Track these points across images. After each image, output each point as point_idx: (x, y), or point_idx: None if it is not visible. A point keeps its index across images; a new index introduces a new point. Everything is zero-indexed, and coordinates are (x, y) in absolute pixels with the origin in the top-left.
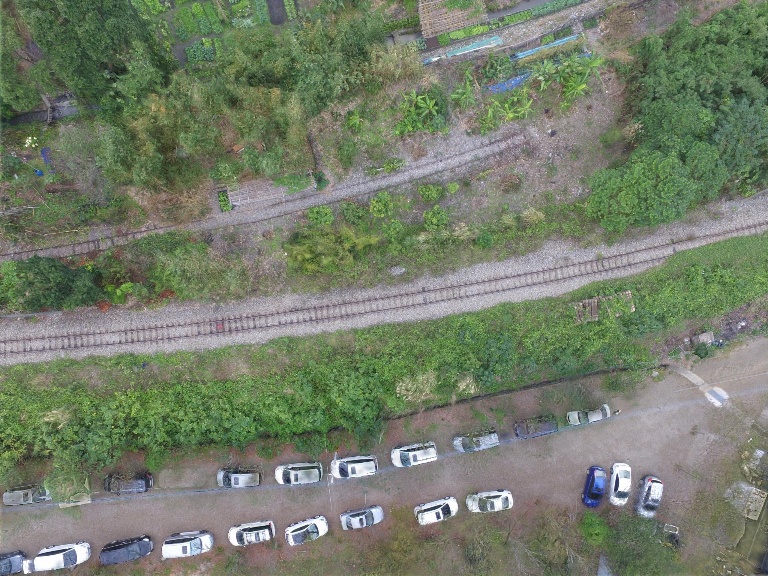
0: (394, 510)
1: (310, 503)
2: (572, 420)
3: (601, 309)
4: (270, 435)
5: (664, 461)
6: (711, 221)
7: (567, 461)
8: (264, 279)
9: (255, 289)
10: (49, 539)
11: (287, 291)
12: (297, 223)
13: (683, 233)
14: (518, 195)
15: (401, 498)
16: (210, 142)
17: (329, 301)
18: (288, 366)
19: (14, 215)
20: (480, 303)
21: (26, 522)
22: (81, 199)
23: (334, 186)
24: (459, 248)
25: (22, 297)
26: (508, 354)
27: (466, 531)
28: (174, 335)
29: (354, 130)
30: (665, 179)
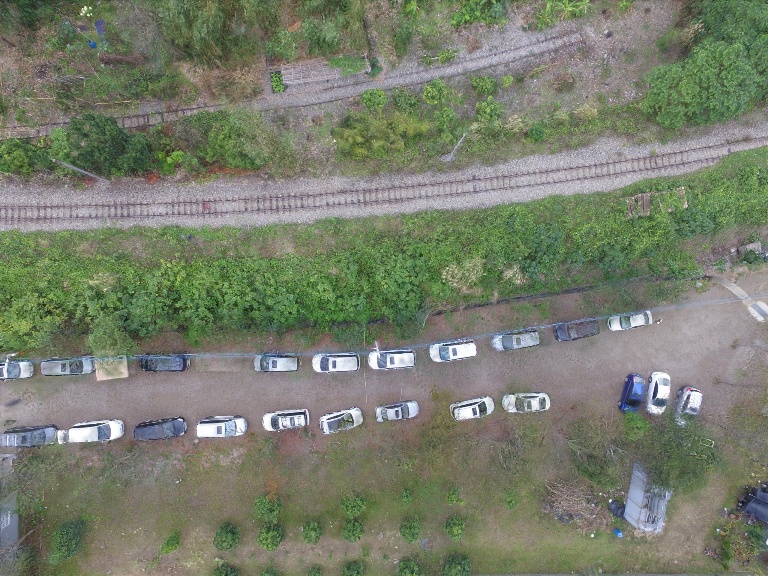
0: (435, 393)
1: (345, 395)
2: (613, 325)
3: (653, 204)
4: (309, 323)
5: (703, 373)
6: (767, 123)
7: (605, 368)
8: (313, 161)
9: (304, 170)
10: (83, 415)
11: (336, 174)
12: (348, 110)
13: (739, 134)
14: (571, 95)
15: None
16: (272, 5)
17: (378, 185)
18: (334, 246)
19: (66, 83)
20: (530, 194)
21: (61, 396)
22: (133, 73)
23: (387, 74)
24: (510, 141)
25: (76, 150)
26: (556, 246)
27: (500, 432)
28: (221, 210)
29: (410, 18)
30: (729, 67)
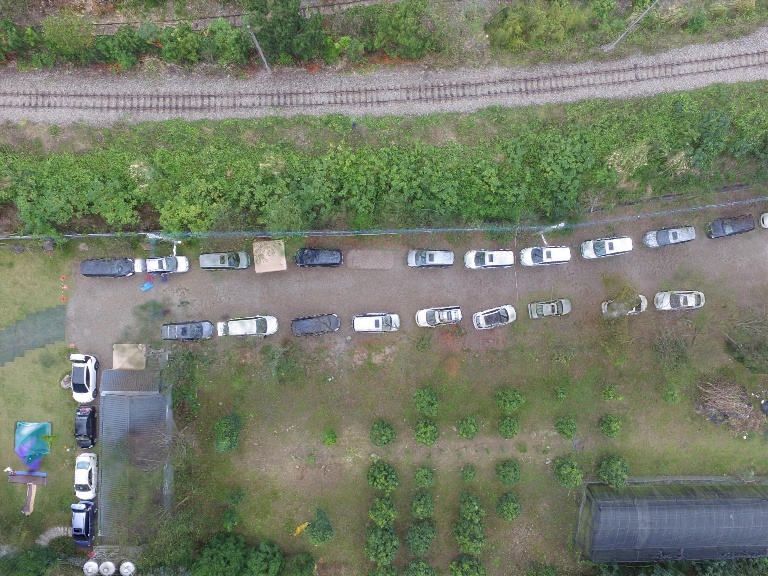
0: (606, 277)
1: (496, 293)
2: (767, 222)
3: None
4: (461, 220)
5: None
6: None
7: (756, 267)
8: (471, 52)
9: (463, 61)
10: (236, 312)
11: (495, 64)
12: (501, 5)
13: None
14: None
15: (588, 294)
16: None
17: (539, 74)
18: None
19: None
20: (693, 82)
21: (214, 293)
22: None
23: None
24: (668, 33)
25: (258, 26)
26: (721, 133)
27: (652, 331)
28: (383, 99)
29: None
30: None
